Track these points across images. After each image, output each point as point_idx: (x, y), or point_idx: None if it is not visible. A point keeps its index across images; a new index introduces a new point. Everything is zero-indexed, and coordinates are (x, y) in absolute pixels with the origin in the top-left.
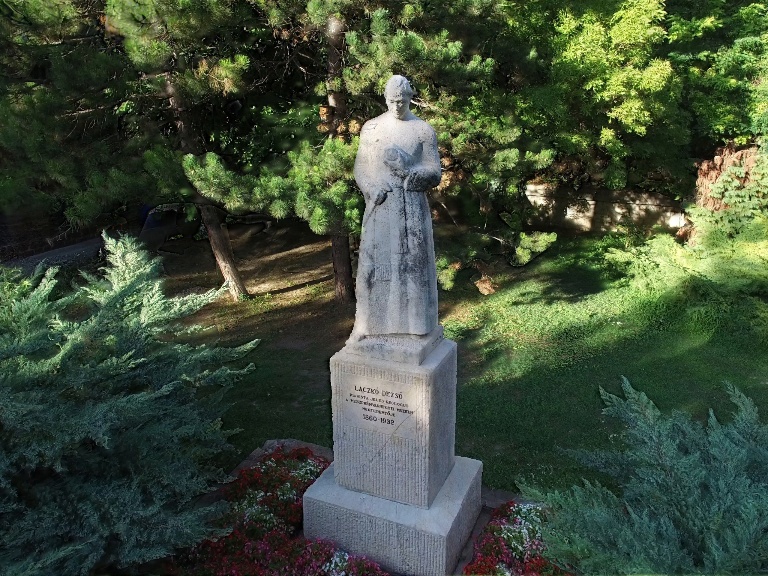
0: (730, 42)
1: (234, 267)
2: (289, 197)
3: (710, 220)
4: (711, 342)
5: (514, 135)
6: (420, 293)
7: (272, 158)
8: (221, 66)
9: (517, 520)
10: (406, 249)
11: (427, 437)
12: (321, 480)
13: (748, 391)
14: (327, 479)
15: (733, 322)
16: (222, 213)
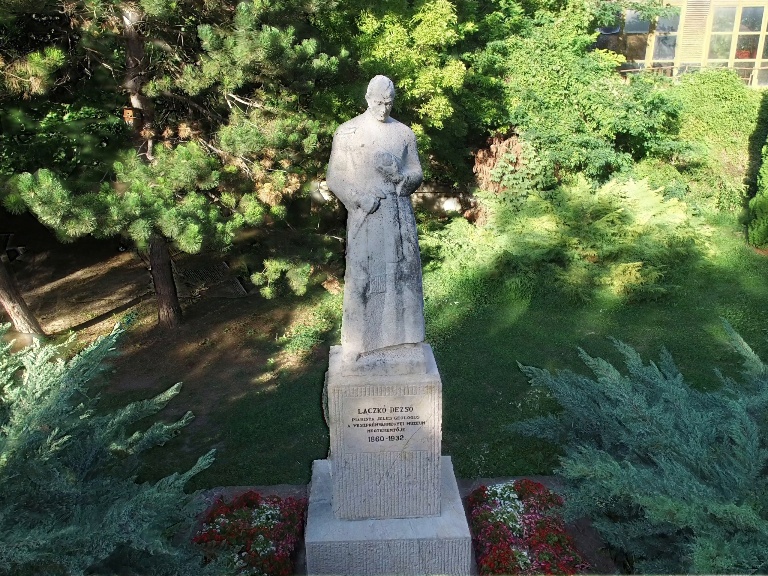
0: (483, 45)
1: (25, 306)
2: (148, 215)
3: (496, 202)
4: (532, 307)
5: None
6: (417, 301)
7: (81, 171)
8: (29, 62)
9: (497, 502)
10: (402, 257)
11: None
12: (314, 521)
13: (583, 343)
14: (320, 518)
15: (543, 287)
16: (0, 243)
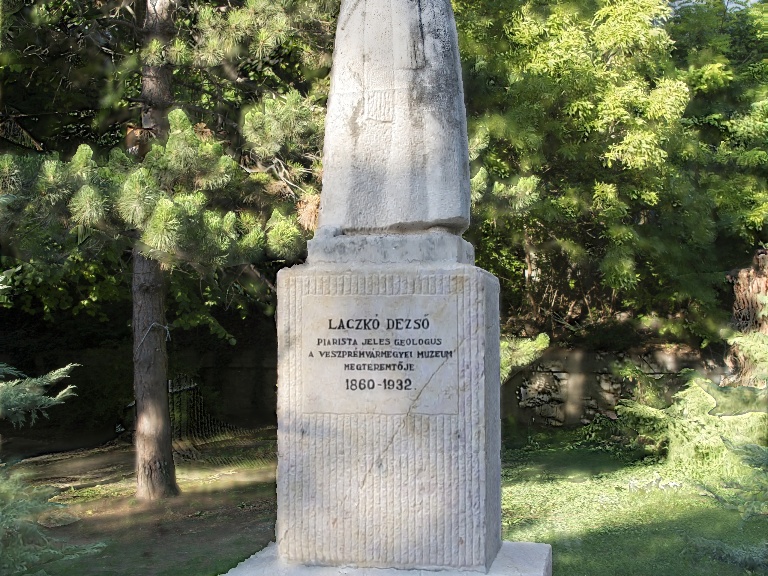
0: (744, 108)
1: None
2: (104, 193)
3: None
4: None
5: (476, 148)
6: (449, 139)
7: None
8: None
9: None
10: (422, 61)
11: (481, 402)
12: (241, 567)
13: None
14: (253, 566)
15: None
16: None
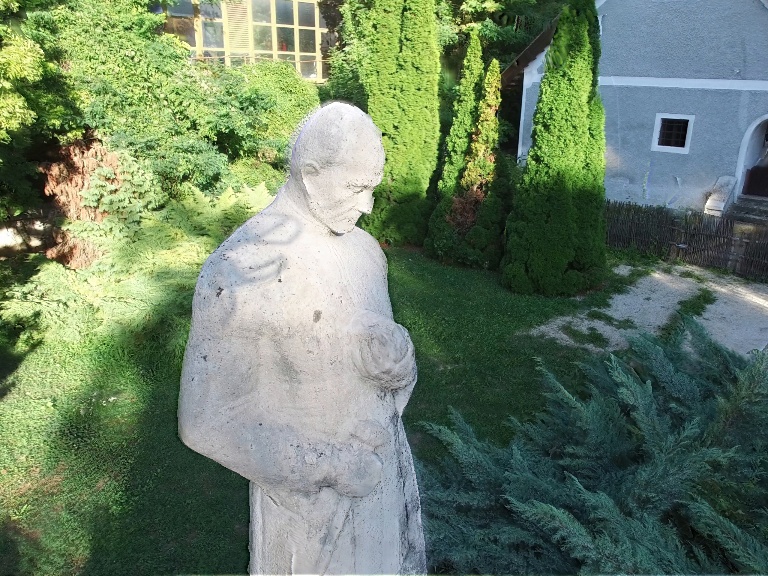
0: None
1: None
2: None
3: (101, 234)
4: None
5: None
6: None
7: None
8: None
9: None
10: (407, 550)
11: None
12: None
13: None
14: None
15: None
16: None
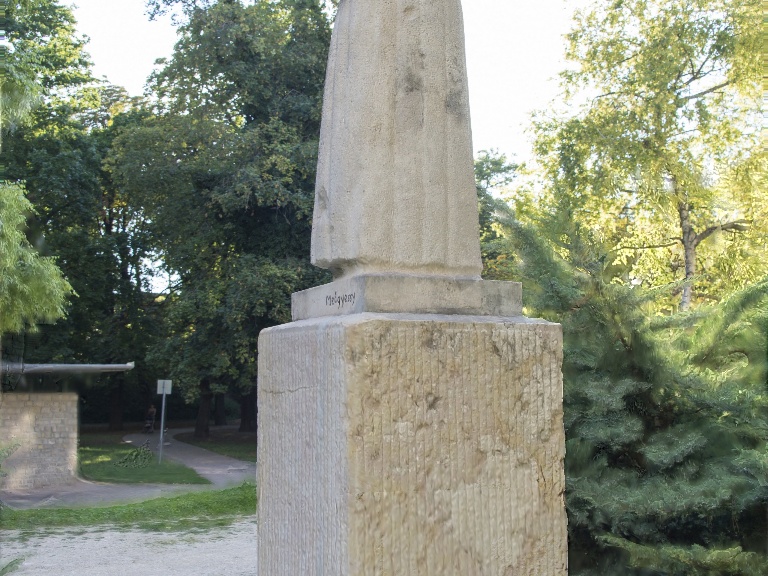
0: None
1: None
2: None
3: None
4: None
5: None
6: None
7: None
8: None
9: None
10: None
11: None
12: None
13: None
14: None
15: None
16: None
